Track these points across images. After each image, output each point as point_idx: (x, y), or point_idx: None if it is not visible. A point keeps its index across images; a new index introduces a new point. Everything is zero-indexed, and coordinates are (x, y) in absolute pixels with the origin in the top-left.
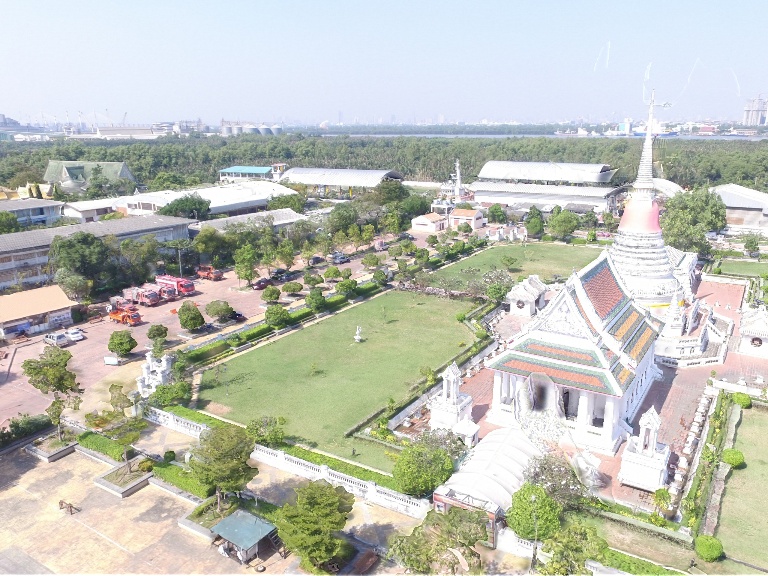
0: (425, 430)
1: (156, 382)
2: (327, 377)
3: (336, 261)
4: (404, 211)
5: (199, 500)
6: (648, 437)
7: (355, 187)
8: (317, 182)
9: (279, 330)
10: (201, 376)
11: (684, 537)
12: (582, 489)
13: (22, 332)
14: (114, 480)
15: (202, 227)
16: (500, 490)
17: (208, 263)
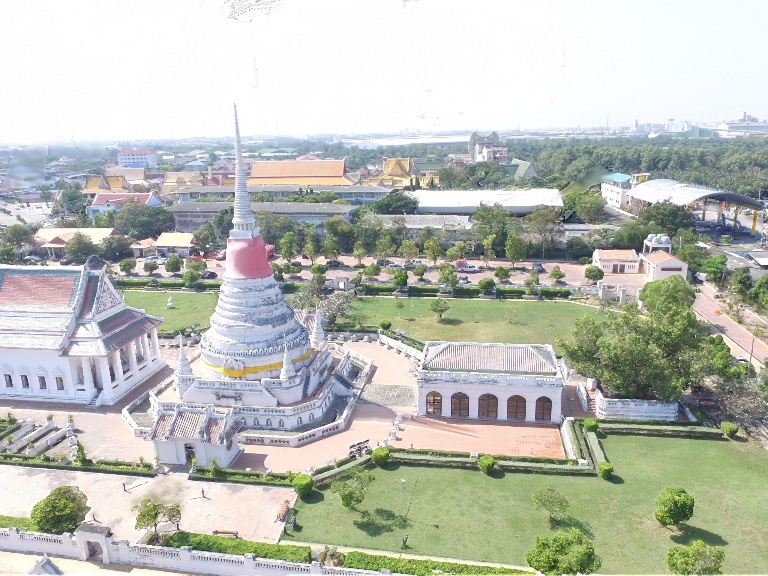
0: None
1: None
2: None
3: None
4: (612, 242)
5: None
6: None
7: None
8: (646, 197)
9: None
10: None
11: None
12: None
13: (163, 254)
14: None
15: None
16: None
17: None
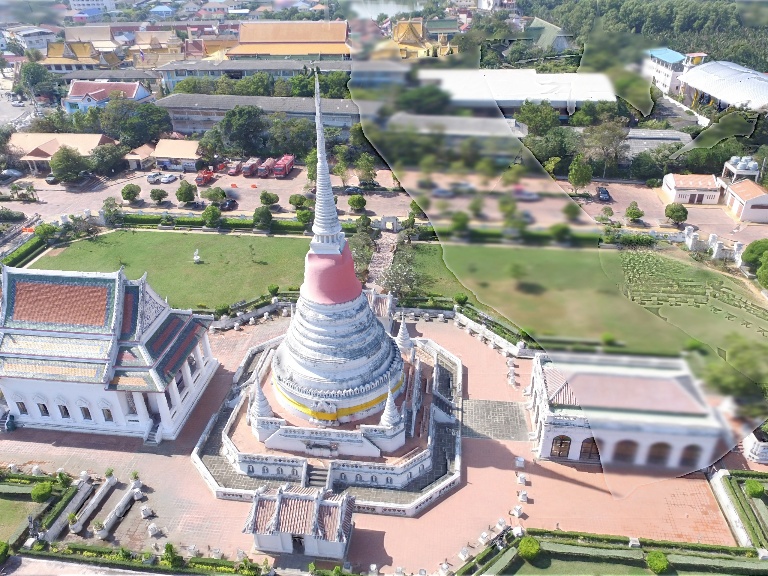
0: None
1: (54, 221)
2: (115, 270)
3: None
4: (684, 160)
5: None
6: None
7: None
8: (705, 88)
9: (206, 227)
10: (111, 232)
11: None
12: None
13: (165, 166)
14: None
15: None
16: None
17: None
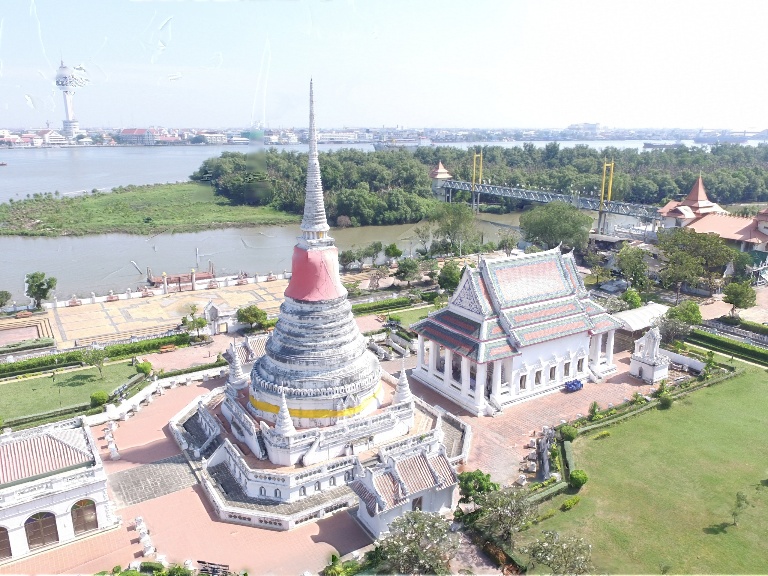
0: None
1: None
2: None
3: None
4: None
5: None
6: None
7: None
8: None
9: None
10: None
11: None
12: None
13: None
14: None
15: None
16: None
17: None
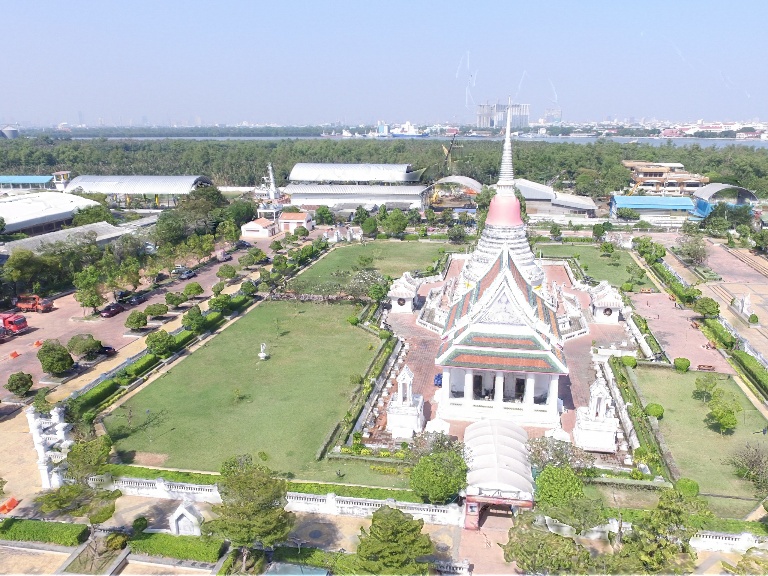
0: (413, 436)
1: (67, 441)
2: (254, 402)
3: (183, 276)
4: None
5: (209, 565)
6: (599, 405)
7: (162, 195)
8: (115, 191)
9: (167, 359)
10: (102, 425)
11: (666, 484)
12: (585, 461)
13: None
14: (82, 570)
15: (13, 250)
16: (519, 478)
17: (25, 292)
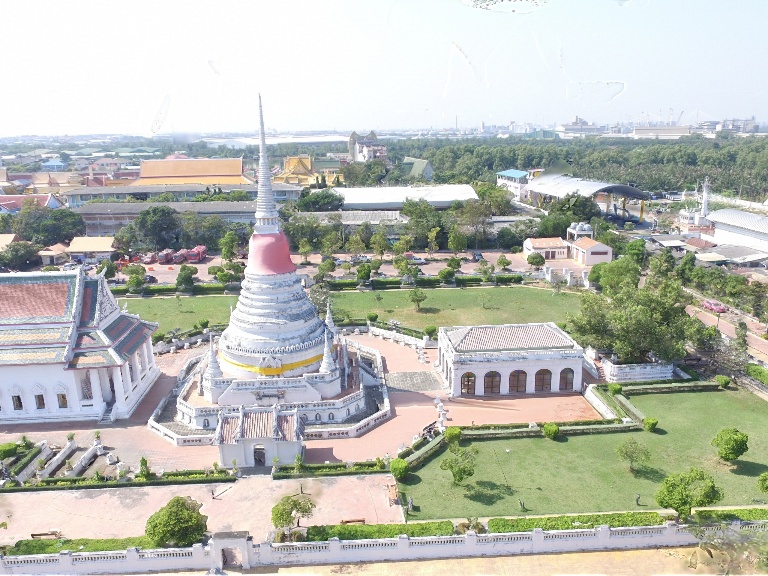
0: None
1: None
2: None
3: None
4: (537, 231)
5: None
6: None
7: None
8: (546, 191)
9: (129, 294)
10: None
11: None
12: None
13: (79, 260)
14: None
15: None
16: None
17: None
